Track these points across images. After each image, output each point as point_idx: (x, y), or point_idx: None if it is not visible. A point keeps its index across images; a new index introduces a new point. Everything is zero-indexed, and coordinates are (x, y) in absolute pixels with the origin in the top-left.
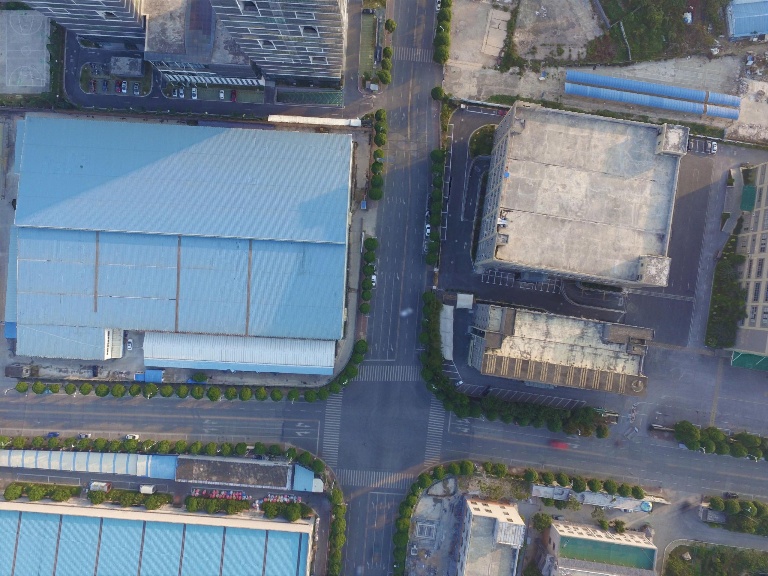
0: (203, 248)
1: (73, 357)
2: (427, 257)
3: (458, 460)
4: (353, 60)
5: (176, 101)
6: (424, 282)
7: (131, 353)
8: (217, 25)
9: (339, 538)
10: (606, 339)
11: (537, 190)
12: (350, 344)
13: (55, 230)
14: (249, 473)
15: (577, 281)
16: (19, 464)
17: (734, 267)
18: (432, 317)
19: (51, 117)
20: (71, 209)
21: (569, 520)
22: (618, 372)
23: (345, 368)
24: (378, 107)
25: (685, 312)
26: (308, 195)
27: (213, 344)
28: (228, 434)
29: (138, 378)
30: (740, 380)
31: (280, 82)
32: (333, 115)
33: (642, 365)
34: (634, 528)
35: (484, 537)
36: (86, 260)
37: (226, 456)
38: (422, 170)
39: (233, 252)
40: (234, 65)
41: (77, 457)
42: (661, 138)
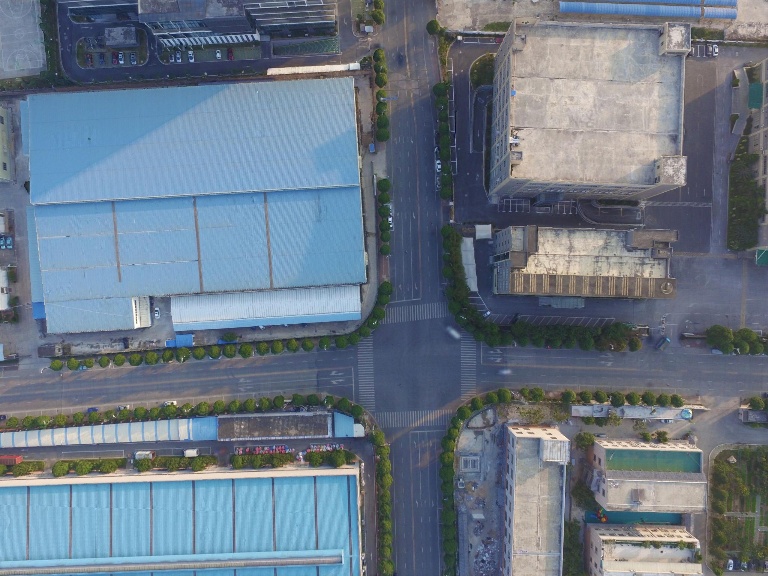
0: (219, 206)
1: (103, 329)
2: (441, 191)
3: (494, 390)
4: (345, 5)
5: (174, 66)
6: (440, 218)
7: (159, 321)
8: None
9: (386, 478)
10: (630, 246)
11: (545, 105)
12: (374, 288)
13: (71, 205)
14: (290, 425)
15: (593, 200)
16: (63, 442)
17: (748, 167)
18: (453, 250)
19: None
20: (84, 182)
21: (611, 437)
22: (645, 278)
23: (372, 312)
24: (375, 49)
25: (704, 218)
26: (317, 141)
27: (239, 302)
28: (264, 390)
29: (169, 344)
30: (766, 280)
31: (275, 35)
32: (331, 62)
33: (669, 268)
34: (676, 438)
35: (530, 458)
36: (105, 231)
37: (265, 412)
38: (426, 107)
39: (249, 207)
40: (229, 17)
41: (119, 429)
42: (664, 38)
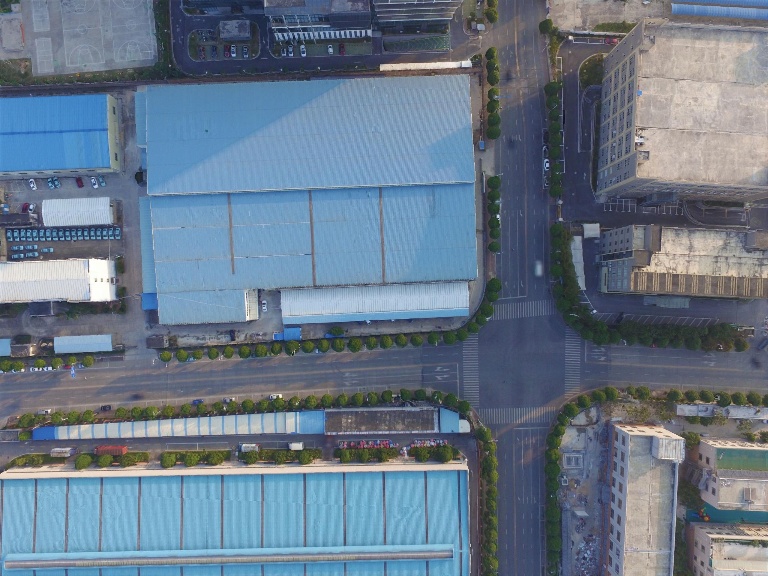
0: (334, 200)
1: (215, 321)
2: (552, 189)
3: (598, 389)
4: None
5: (285, 60)
6: (547, 217)
7: (266, 314)
8: None
9: (493, 474)
10: (751, 246)
11: (670, 106)
12: (480, 285)
13: (187, 196)
14: (397, 420)
15: (699, 201)
16: (169, 433)
17: None
18: (564, 248)
19: None
20: (201, 173)
21: None
22: None
23: (479, 308)
24: (485, 47)
25: None
26: (433, 138)
27: (349, 296)
28: (369, 385)
29: (277, 337)
30: None
31: (387, 31)
32: (442, 59)
33: None
34: None
35: (642, 456)
36: (220, 223)
37: (370, 406)
38: (535, 106)
39: (364, 201)
40: (354, 12)
41: (225, 421)
42: None
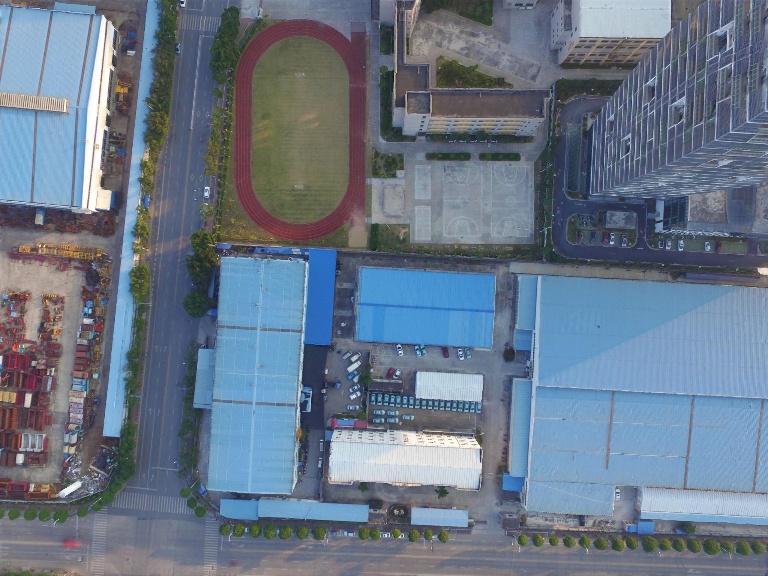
0: (716, 407)
1: (582, 513)
2: None
3: None
4: None
5: (660, 252)
6: None
7: (616, 502)
8: (757, 194)
9: None
10: None
11: None
12: None
13: (572, 389)
14: None
15: None
16: None
17: None
18: None
19: (536, 267)
20: (592, 370)
21: None
22: None
23: None
24: None
25: None
26: None
27: (710, 498)
28: None
29: (630, 529)
30: None
31: None
32: None
33: None
34: None
35: None
36: (601, 419)
37: None
38: None
39: (745, 411)
40: None
41: None
42: None
